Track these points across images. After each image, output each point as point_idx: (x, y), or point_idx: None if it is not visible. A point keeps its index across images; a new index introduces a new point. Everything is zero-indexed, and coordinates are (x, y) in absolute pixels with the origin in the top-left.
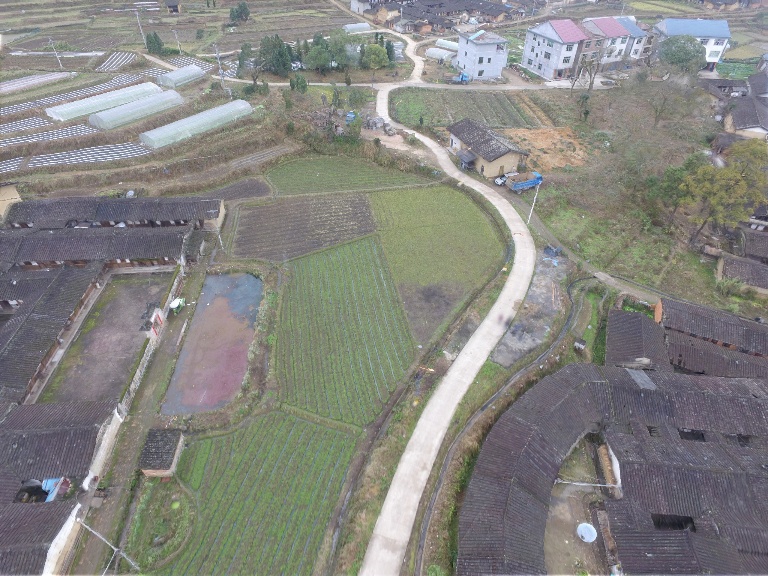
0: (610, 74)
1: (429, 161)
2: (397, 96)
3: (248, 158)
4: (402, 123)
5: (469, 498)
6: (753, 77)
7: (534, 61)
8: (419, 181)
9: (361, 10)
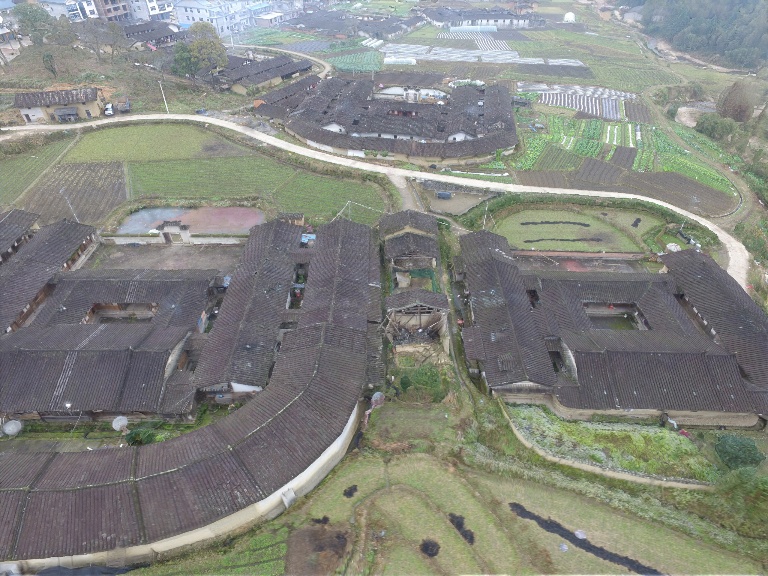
0: None
1: (44, 132)
2: None
3: None
4: None
5: (341, 145)
6: (72, 25)
7: None
8: (67, 142)
9: None
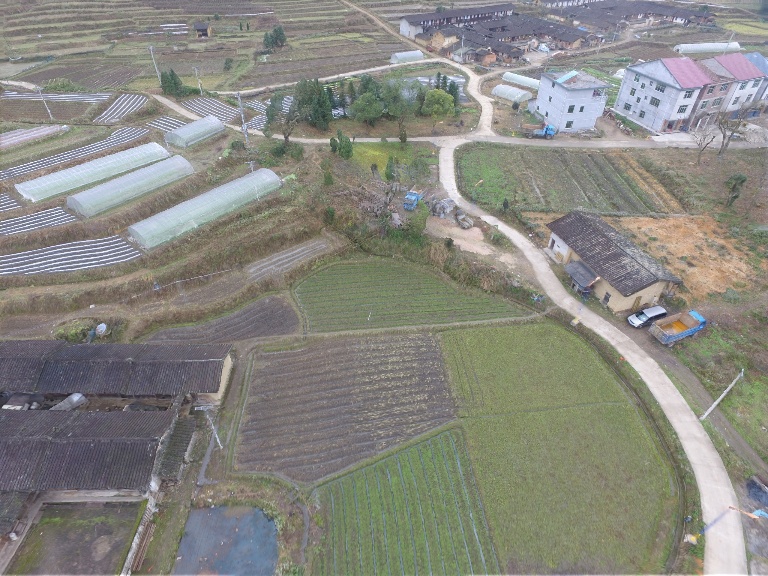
0: None
1: (523, 275)
2: (464, 156)
3: (271, 261)
4: (475, 201)
5: None
6: None
7: (634, 107)
8: (512, 311)
9: (412, 34)
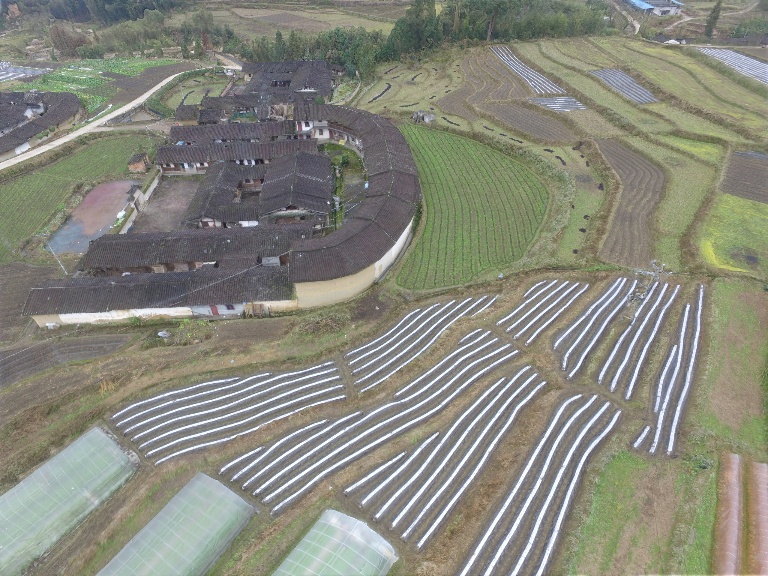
0: None
1: None
2: None
3: None
4: None
5: (6, 149)
6: None
7: None
8: None
9: None
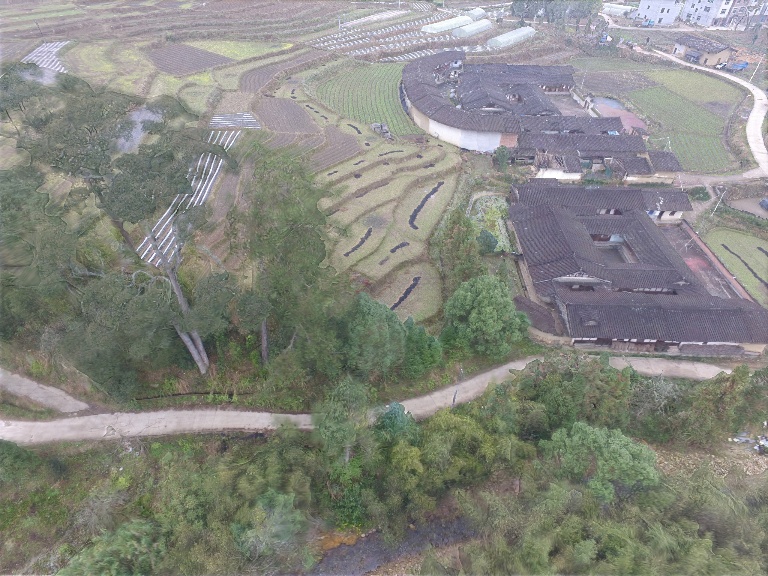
0: (750, 24)
1: None
2: None
3: None
4: None
5: None
6: None
7: (693, 15)
8: (665, 68)
9: None
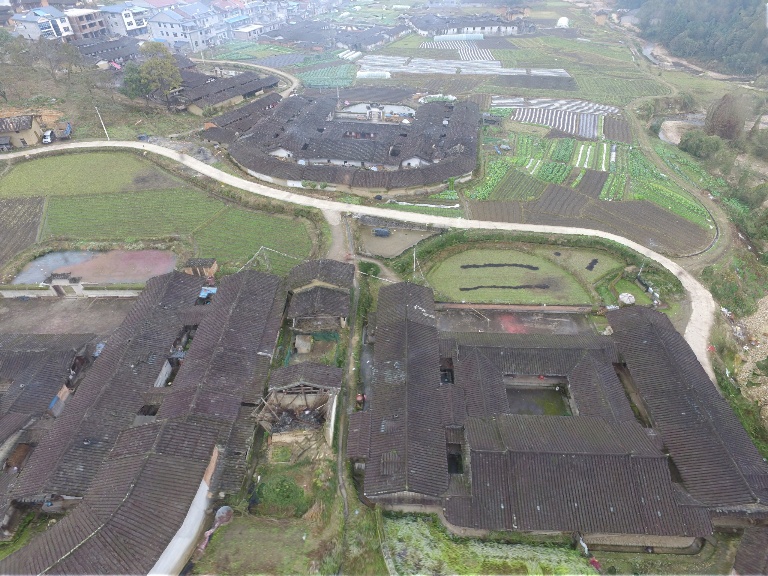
0: None
1: None
2: None
3: None
4: None
5: (279, 175)
6: None
7: None
8: None
9: None
